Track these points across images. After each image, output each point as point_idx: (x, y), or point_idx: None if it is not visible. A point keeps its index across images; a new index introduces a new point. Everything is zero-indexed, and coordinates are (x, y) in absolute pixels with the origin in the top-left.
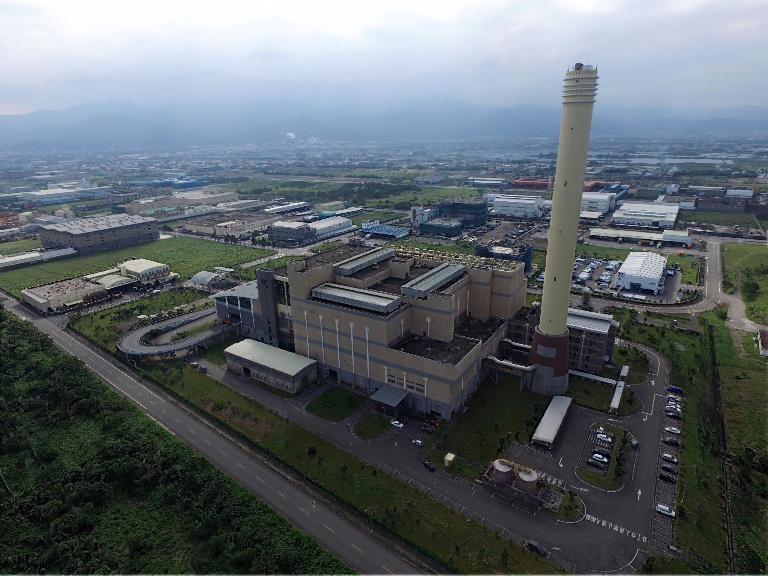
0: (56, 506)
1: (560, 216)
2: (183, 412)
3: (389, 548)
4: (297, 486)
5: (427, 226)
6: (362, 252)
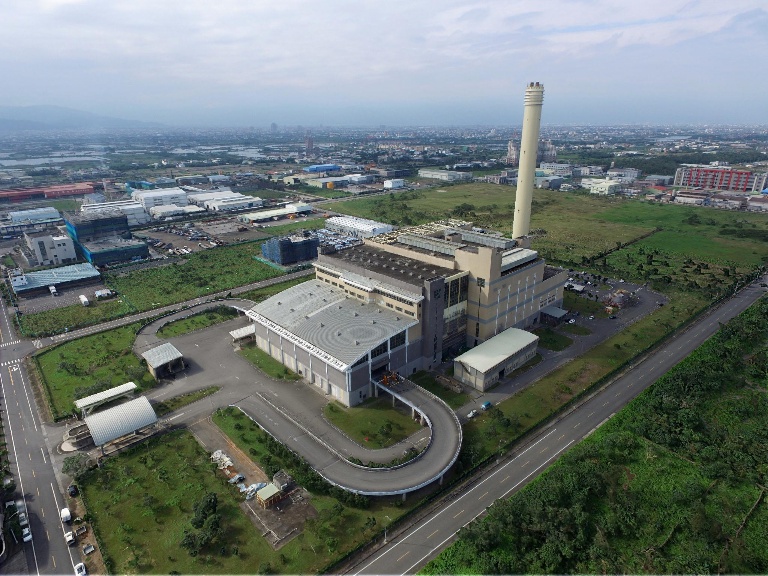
0: (760, 444)
1: (533, 172)
2: (576, 412)
3: (682, 334)
4: (651, 356)
5: (103, 254)
6: (362, 252)
